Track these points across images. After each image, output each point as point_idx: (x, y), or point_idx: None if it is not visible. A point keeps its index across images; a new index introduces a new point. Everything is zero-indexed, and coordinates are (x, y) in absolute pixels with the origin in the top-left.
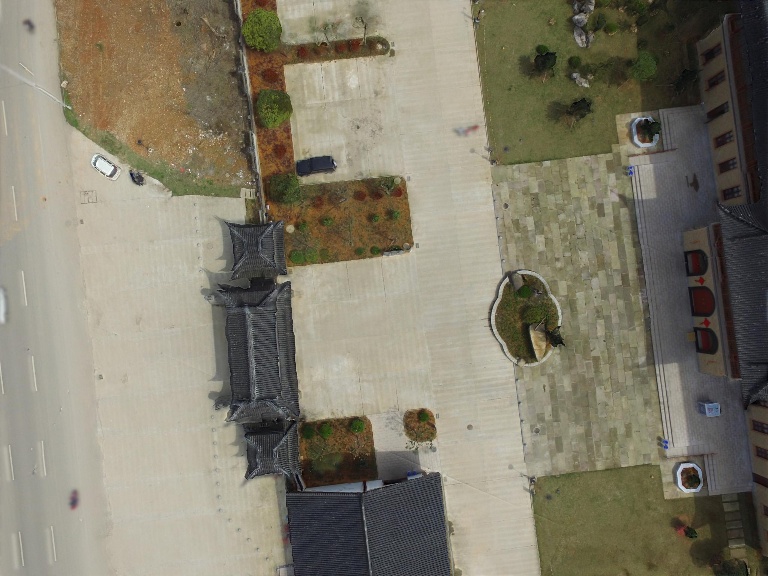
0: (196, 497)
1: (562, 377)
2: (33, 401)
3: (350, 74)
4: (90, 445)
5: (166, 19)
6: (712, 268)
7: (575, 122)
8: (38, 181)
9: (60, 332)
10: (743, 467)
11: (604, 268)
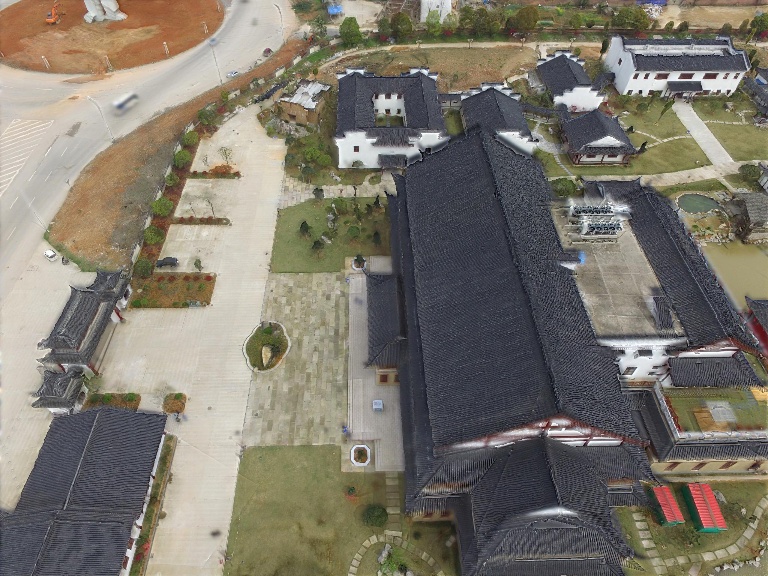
0: None
1: (283, 383)
2: None
3: (205, 230)
4: None
5: (120, 205)
6: None
7: (319, 256)
8: (10, 259)
9: None
10: (402, 451)
11: (324, 325)
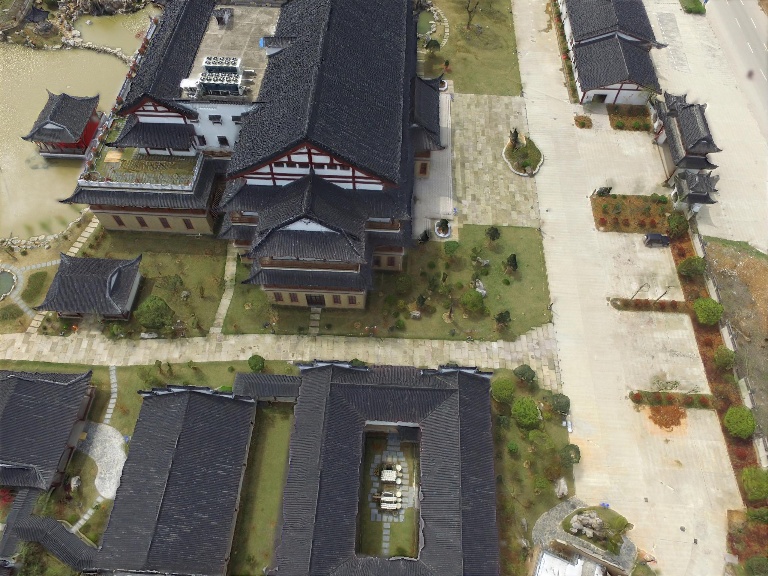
0: None
1: (503, 131)
2: None
3: None
4: None
5: None
6: None
7: None
8: None
9: None
10: None
11: (474, 172)
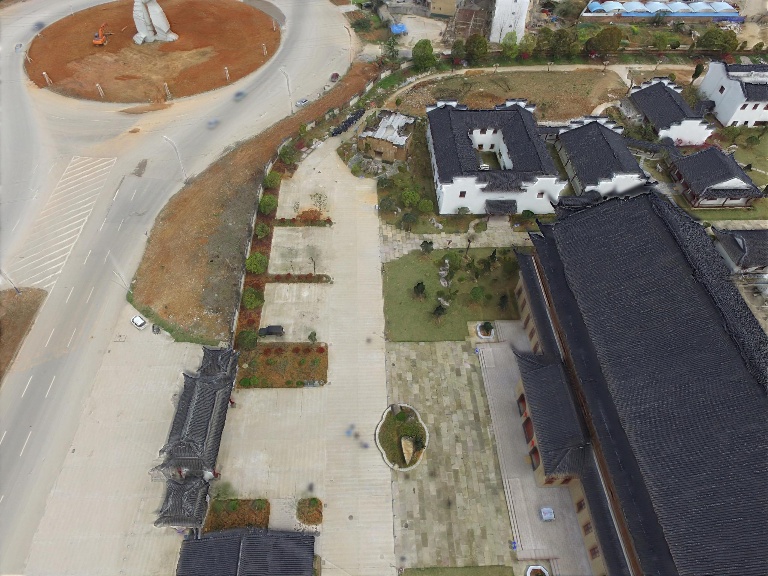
0: (105, 558)
1: (428, 483)
2: (14, 463)
3: (305, 290)
4: (39, 503)
5: (205, 259)
6: (527, 401)
7: (439, 321)
8: (93, 327)
9: (60, 417)
10: (585, 574)
11: (461, 408)
